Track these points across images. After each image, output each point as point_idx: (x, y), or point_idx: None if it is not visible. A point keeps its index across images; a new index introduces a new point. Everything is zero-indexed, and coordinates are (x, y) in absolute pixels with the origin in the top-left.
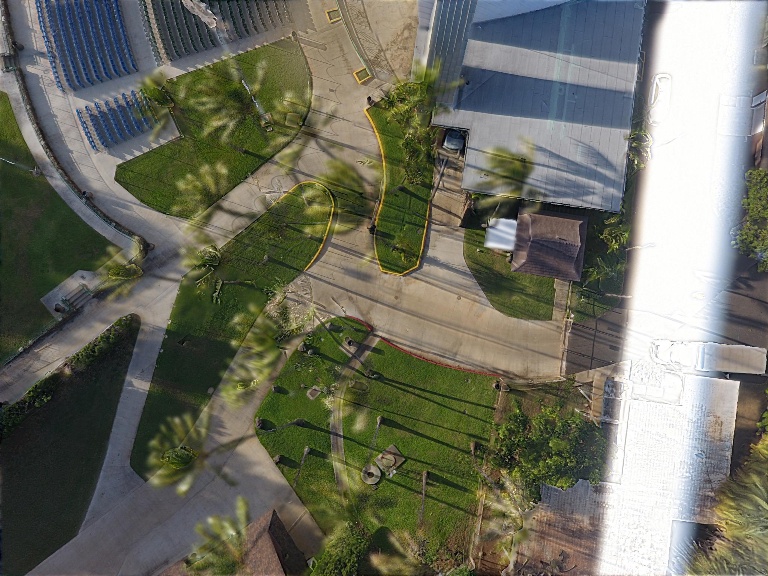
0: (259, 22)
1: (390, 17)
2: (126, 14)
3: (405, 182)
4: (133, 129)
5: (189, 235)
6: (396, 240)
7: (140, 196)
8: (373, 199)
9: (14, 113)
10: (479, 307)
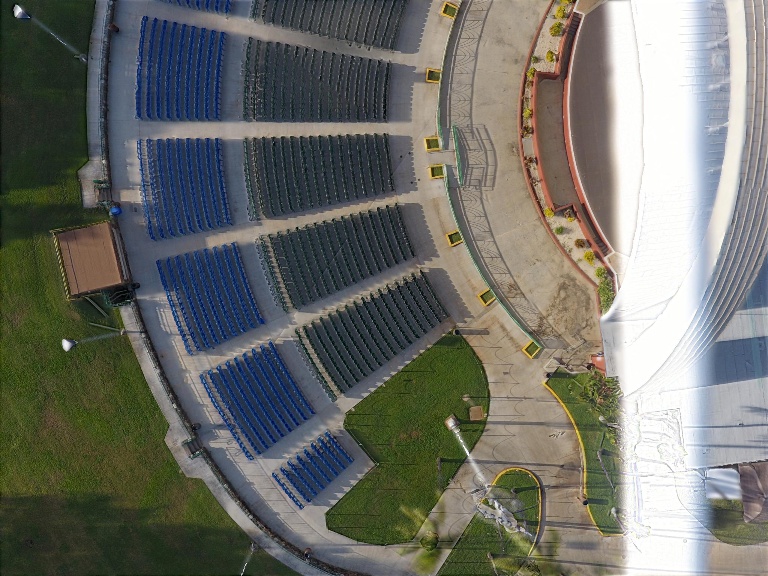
0: (419, 329)
1: (542, 282)
2: (287, 359)
3: (603, 444)
4: (332, 476)
5: (412, 558)
6: (610, 504)
7: (355, 536)
8: (575, 468)
9: (215, 496)
10: (707, 544)
